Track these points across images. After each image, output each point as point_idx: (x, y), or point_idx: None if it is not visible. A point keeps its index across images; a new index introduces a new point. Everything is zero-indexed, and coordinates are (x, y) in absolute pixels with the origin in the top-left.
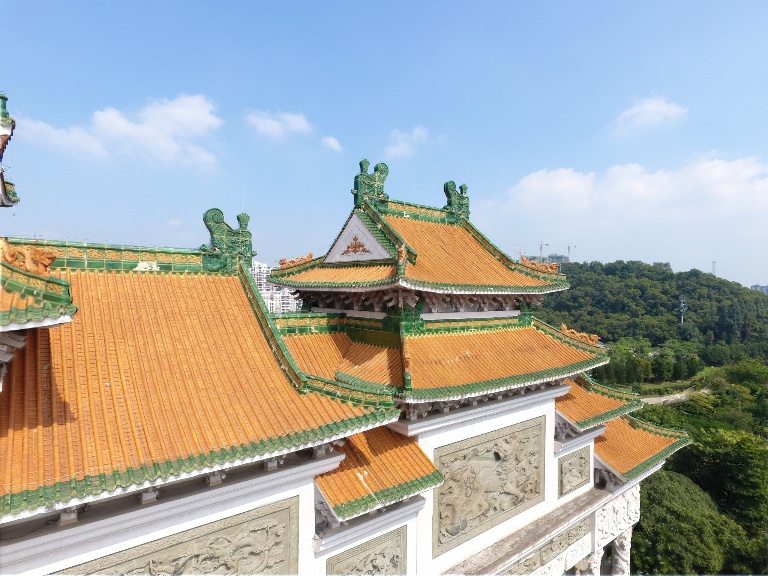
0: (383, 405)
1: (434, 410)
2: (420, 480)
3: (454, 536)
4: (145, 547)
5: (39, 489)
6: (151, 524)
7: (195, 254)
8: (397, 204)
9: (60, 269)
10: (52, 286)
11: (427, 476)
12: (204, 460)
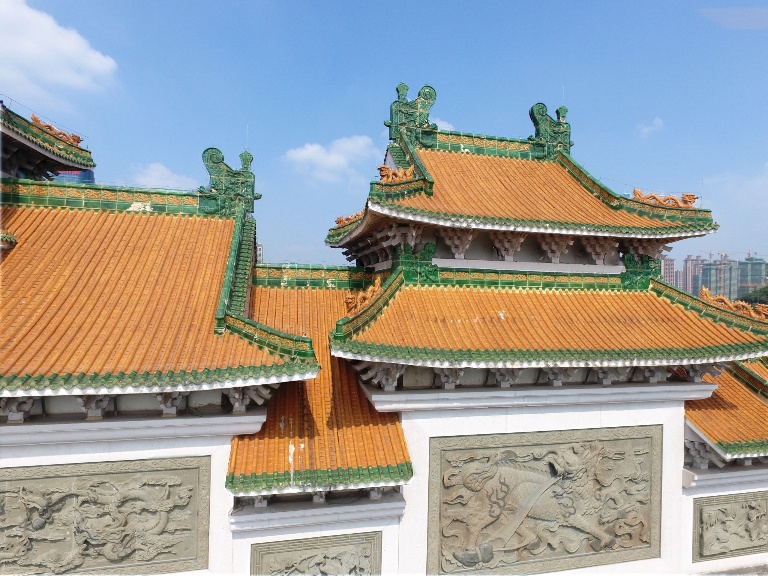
0: (298, 354)
1: (439, 386)
2: (373, 470)
3: (469, 567)
4: (18, 471)
5: None
6: (23, 448)
7: (191, 196)
8: (450, 136)
9: (61, 208)
10: None
11: (387, 467)
12: (33, 380)
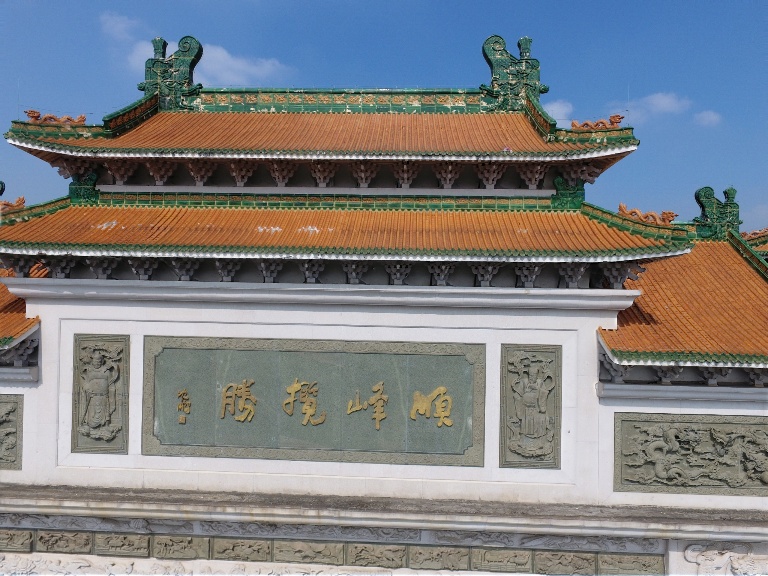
0: None
1: None
2: None
3: None
4: (707, 417)
5: (668, 352)
6: (712, 402)
7: (691, 225)
8: None
9: None
10: (677, 232)
11: None
12: (767, 358)
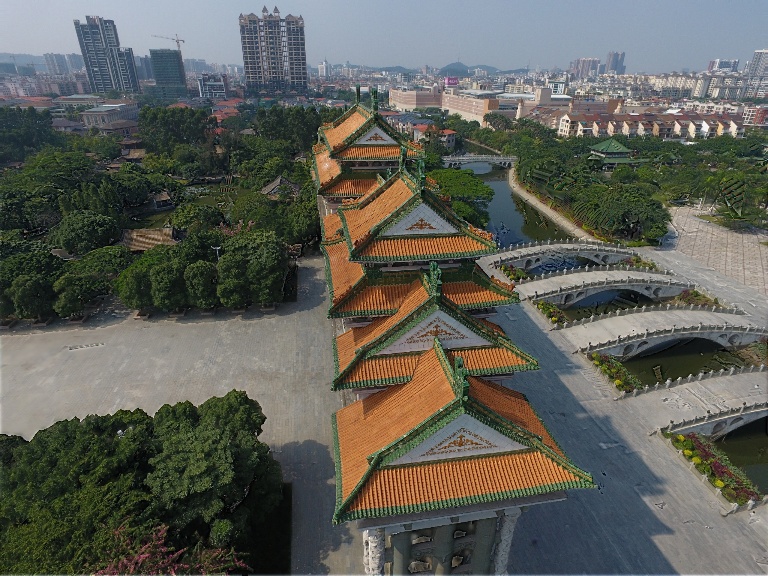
0: None
1: None
2: None
3: None
4: None
5: None
6: None
7: None
8: None
9: None
10: None
11: None
12: None
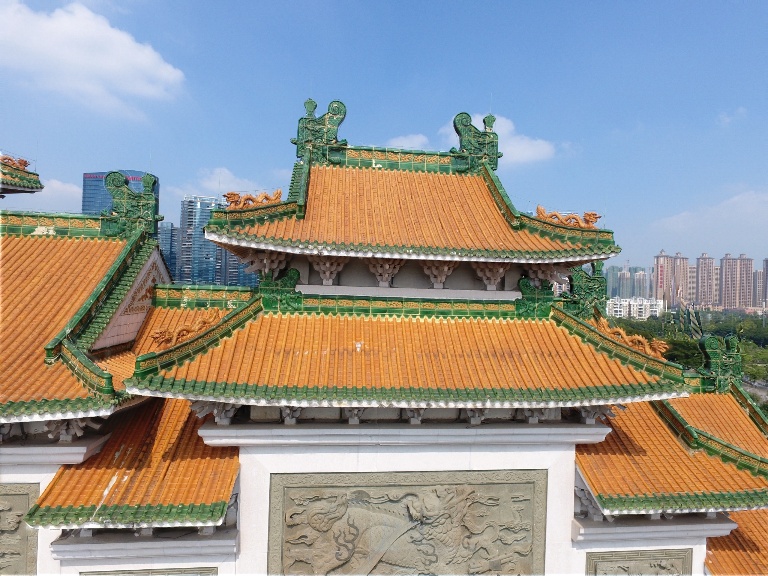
0: (97, 390)
1: None
2: (182, 508)
3: None
4: None
5: None
6: None
7: (93, 219)
8: (361, 151)
9: None
10: None
11: (199, 506)
12: None
